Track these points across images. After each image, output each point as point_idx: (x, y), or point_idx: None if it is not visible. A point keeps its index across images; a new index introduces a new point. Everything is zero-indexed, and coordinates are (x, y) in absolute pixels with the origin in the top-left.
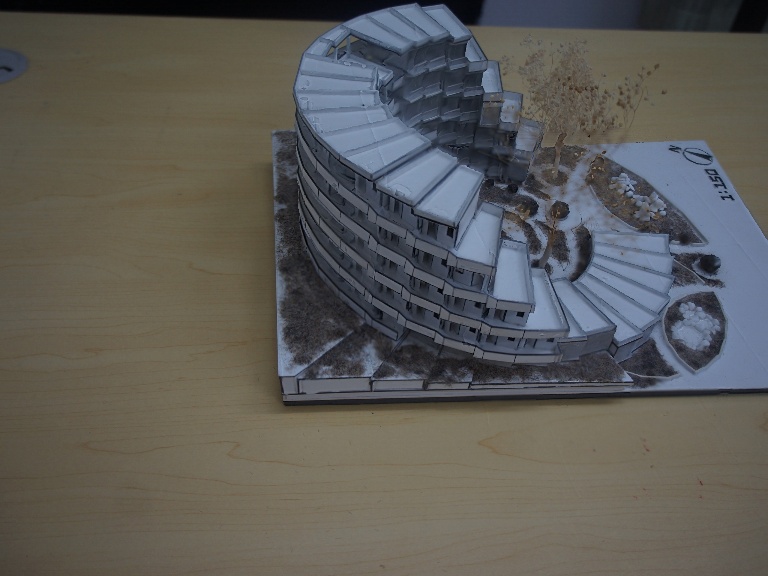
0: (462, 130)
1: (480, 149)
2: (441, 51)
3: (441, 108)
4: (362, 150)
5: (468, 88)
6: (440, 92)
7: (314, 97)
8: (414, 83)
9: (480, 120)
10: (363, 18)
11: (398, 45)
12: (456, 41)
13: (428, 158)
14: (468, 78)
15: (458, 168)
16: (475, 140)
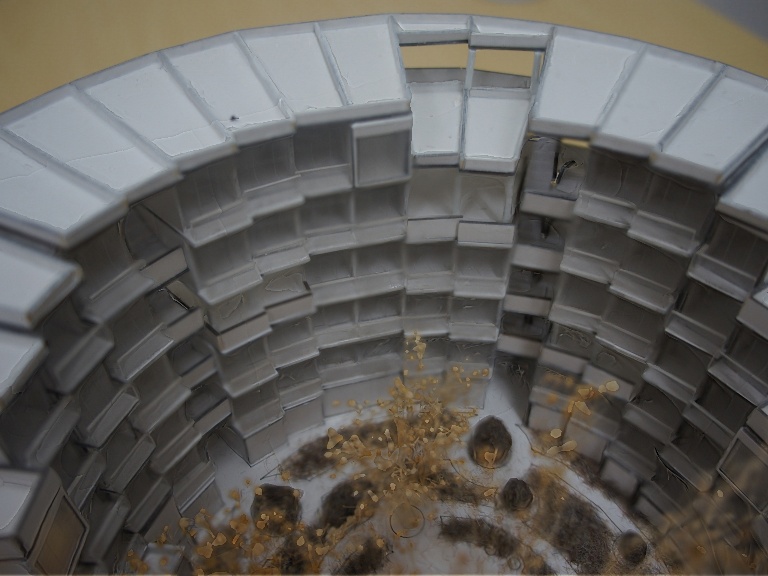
0: (697, 443)
1: (704, 519)
2: (697, 214)
3: (663, 351)
4: (21, 146)
5: (729, 360)
6: (658, 309)
7: (236, 60)
8: (608, 241)
9: (721, 458)
10: (634, 48)
11: (568, 115)
12: (727, 210)
13: (38, 262)
14: (749, 339)
15: (23, 337)
16: (715, 493)
